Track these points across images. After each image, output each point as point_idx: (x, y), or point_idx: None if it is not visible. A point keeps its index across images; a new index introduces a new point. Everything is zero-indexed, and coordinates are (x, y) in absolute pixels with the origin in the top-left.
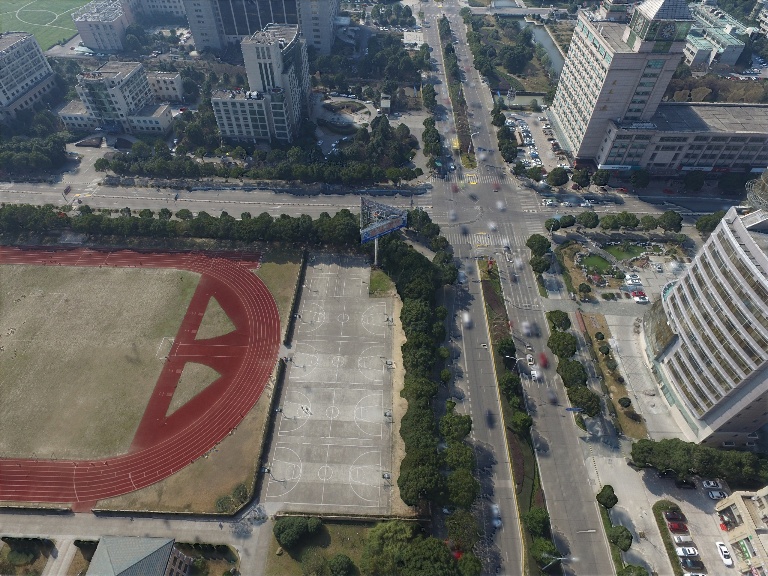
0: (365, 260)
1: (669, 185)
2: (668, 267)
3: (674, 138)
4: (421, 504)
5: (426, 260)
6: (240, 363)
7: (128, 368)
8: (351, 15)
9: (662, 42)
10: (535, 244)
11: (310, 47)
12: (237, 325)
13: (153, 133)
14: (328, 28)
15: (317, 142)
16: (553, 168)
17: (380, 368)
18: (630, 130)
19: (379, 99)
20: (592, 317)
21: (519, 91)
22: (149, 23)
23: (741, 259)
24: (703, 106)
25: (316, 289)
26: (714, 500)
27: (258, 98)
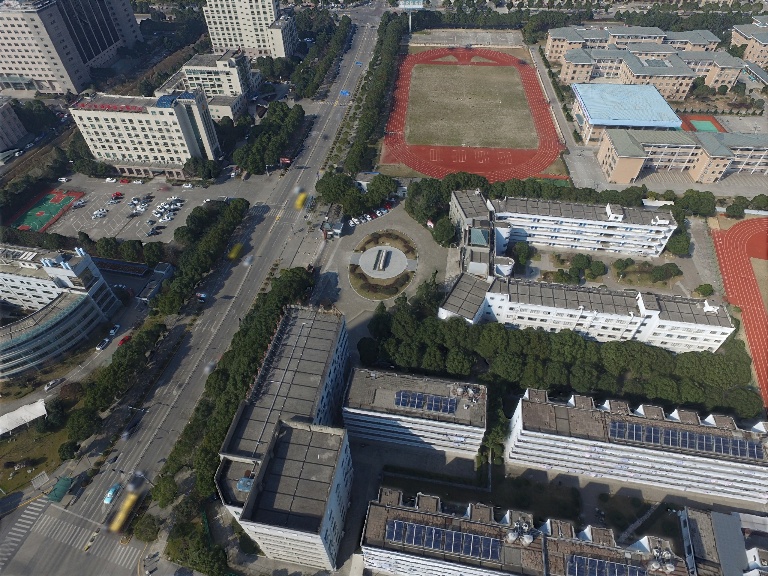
0: None
1: None
2: None
3: None
4: (516, 29)
5: None
6: (469, 53)
7: (476, 71)
8: None
9: None
10: None
11: (139, 41)
12: None
13: (261, 87)
14: None
15: None
16: None
17: None
18: None
19: None
20: None
21: None
22: None
23: None
24: None
25: None
26: (504, 1)
27: None
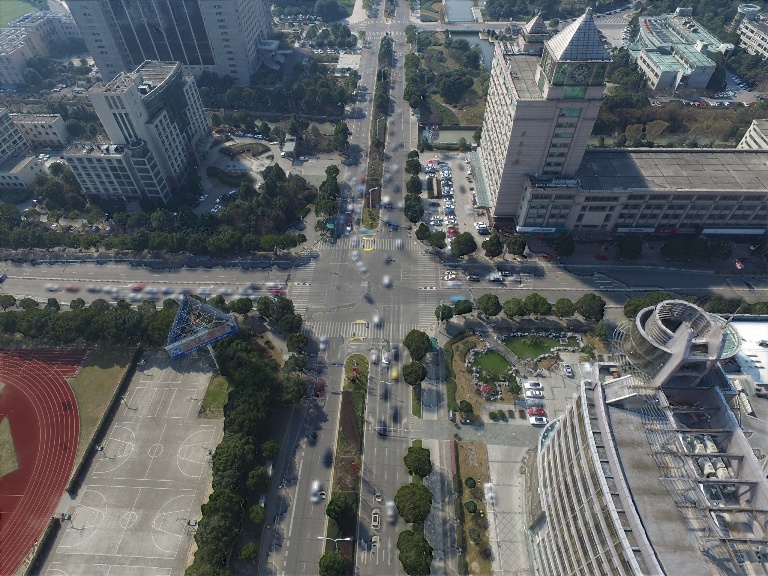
0: (203, 365)
1: (603, 249)
2: (582, 369)
3: (602, 197)
4: None
5: (262, 374)
6: (4, 523)
7: None
8: (287, 36)
9: (574, 87)
10: (412, 344)
11: (225, 77)
12: (21, 462)
13: (15, 189)
14: (243, 56)
15: (200, 197)
16: (468, 227)
17: (179, 531)
18: (547, 189)
19: (284, 141)
20: (470, 448)
21: (452, 125)
22: (64, 51)
23: (592, 459)
24: (645, 152)
25: (136, 406)
26: None
27: (117, 153)
